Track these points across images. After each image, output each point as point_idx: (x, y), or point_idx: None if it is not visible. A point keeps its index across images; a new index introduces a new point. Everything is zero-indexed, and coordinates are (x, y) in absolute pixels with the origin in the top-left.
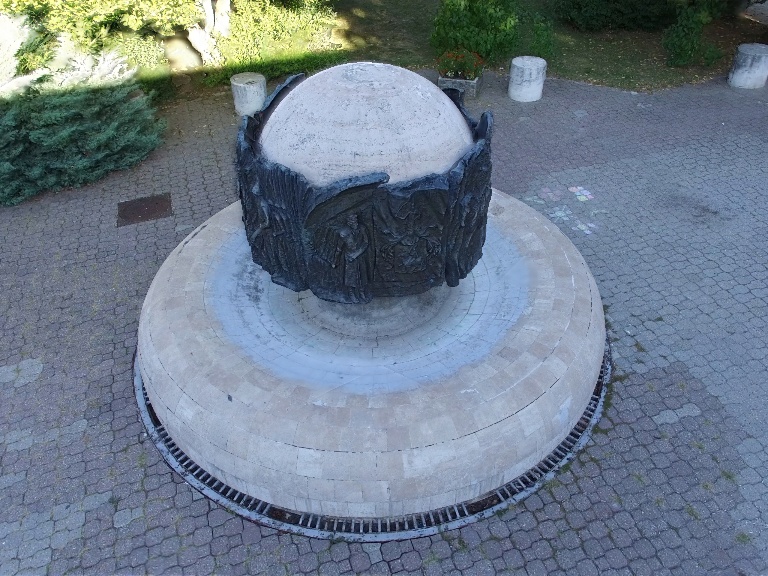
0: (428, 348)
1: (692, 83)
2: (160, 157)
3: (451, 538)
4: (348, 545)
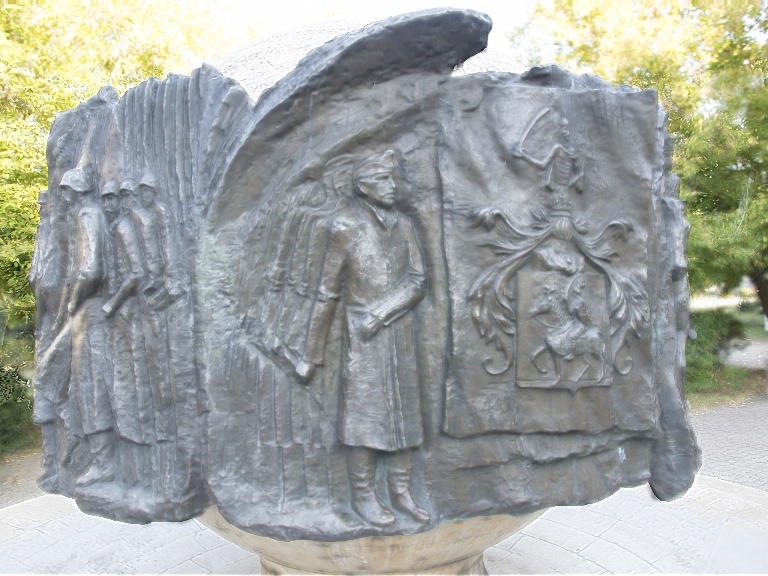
0: None
1: (733, 407)
2: None
3: None
4: None
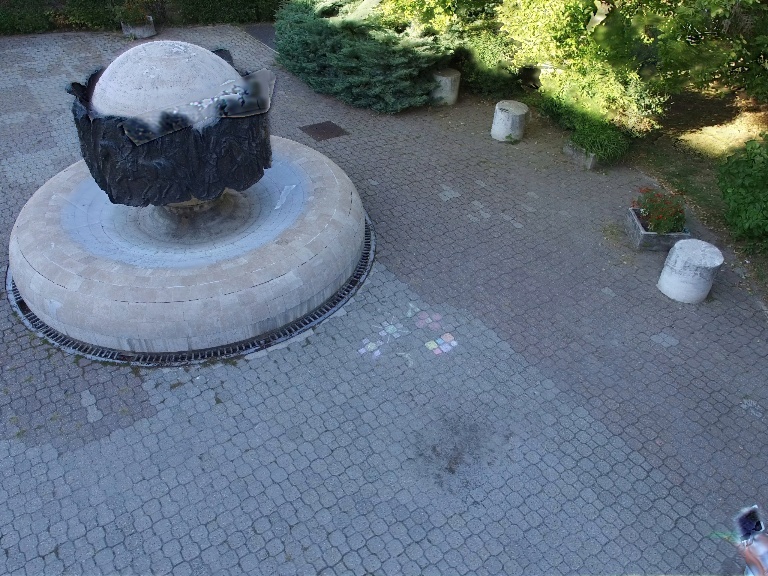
0: (119, 238)
1: None
2: (403, 119)
3: (2, 296)
4: (8, 260)
